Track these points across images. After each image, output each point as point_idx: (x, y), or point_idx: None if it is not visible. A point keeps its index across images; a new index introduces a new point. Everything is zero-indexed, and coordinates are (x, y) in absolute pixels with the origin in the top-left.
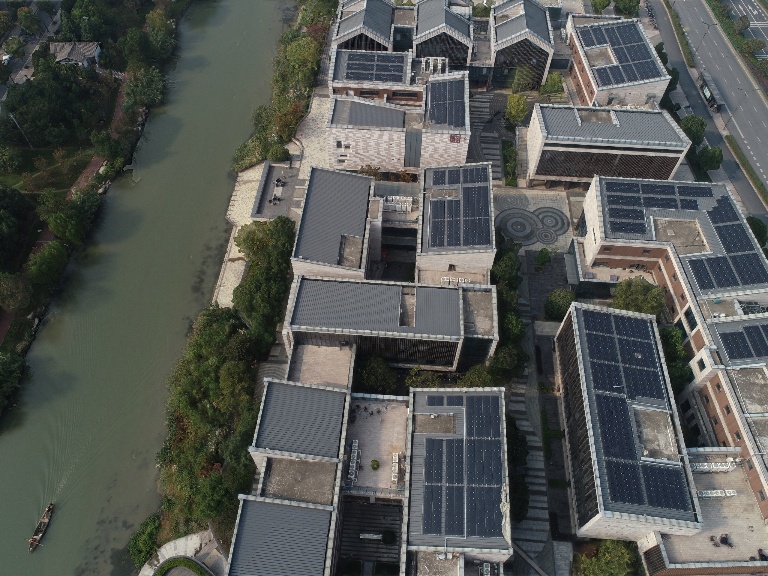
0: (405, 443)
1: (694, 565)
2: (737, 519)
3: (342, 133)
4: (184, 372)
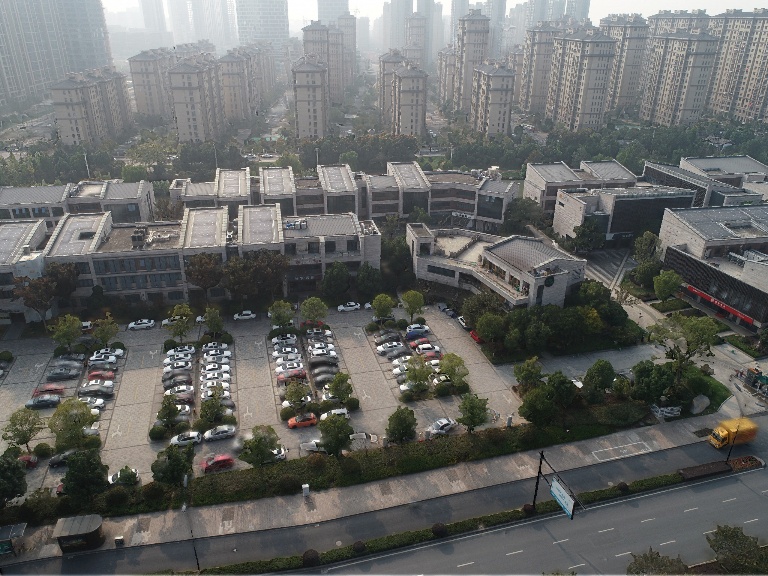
0: None
1: None
2: (737, 271)
3: None
4: None
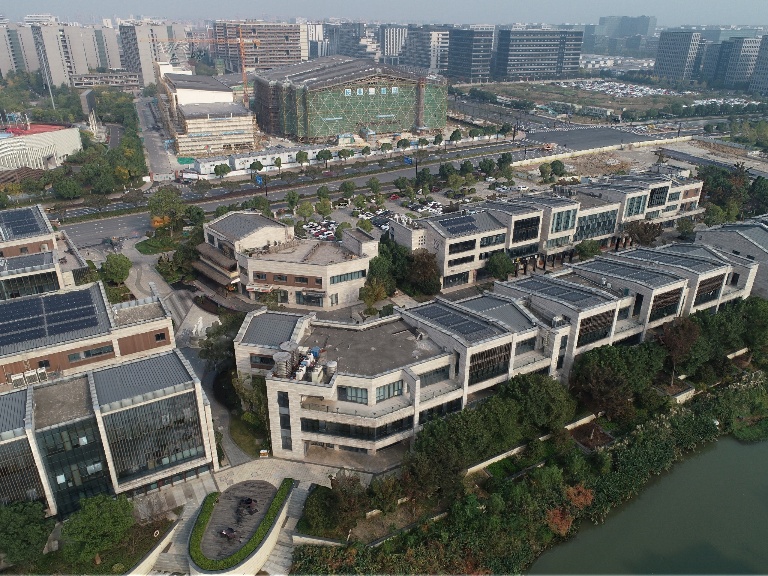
0: None
1: (83, 260)
2: None
3: None
4: None
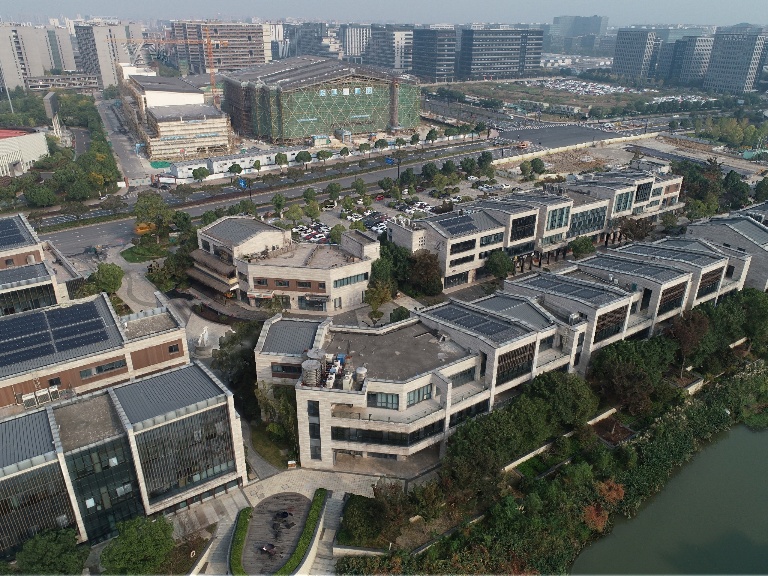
0: (4, 409)
1: (75, 271)
2: None
3: None
4: None
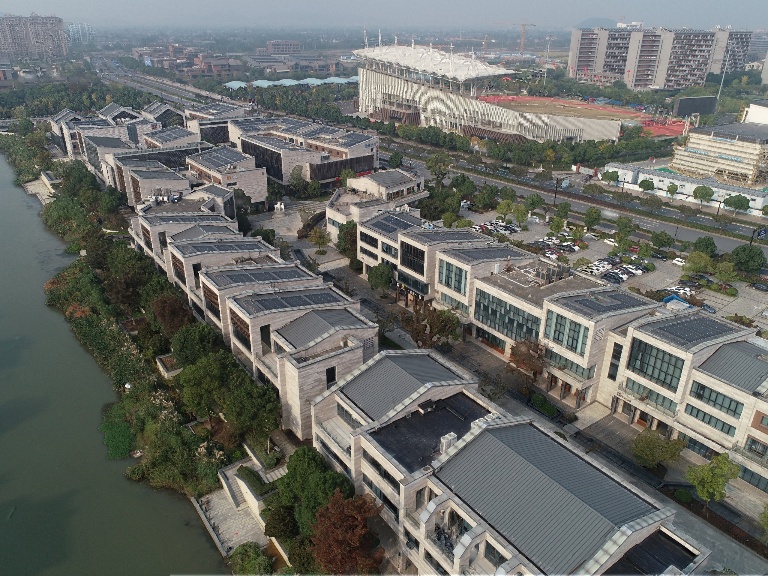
0: None
1: (324, 163)
2: None
3: (91, 133)
4: (52, 211)
